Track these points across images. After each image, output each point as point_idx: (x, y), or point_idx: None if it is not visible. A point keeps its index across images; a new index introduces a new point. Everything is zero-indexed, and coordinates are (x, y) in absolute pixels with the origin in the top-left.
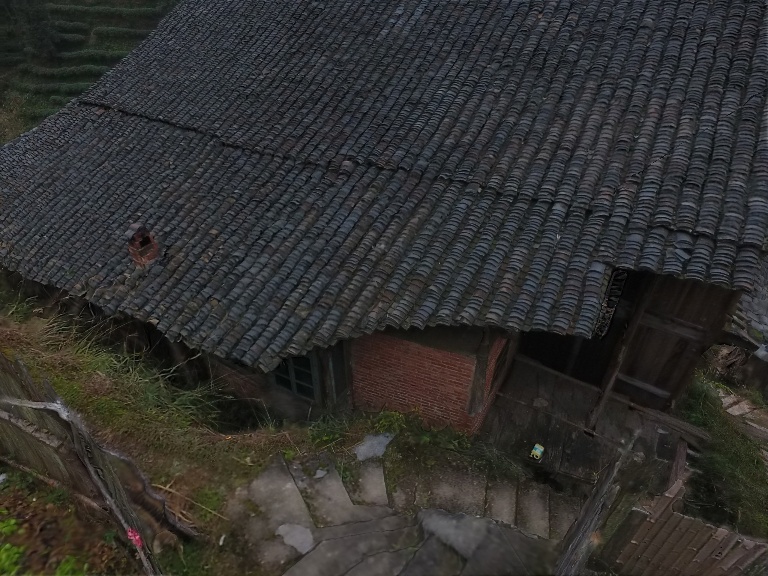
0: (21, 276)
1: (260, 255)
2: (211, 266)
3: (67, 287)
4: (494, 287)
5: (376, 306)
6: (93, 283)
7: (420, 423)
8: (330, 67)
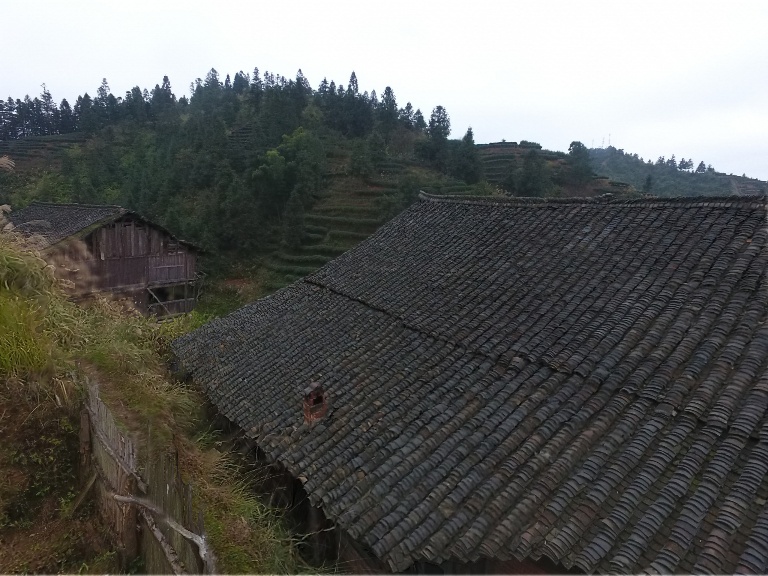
0: (218, 410)
1: (415, 435)
2: (367, 436)
3: (246, 427)
4: (696, 544)
5: (532, 526)
6: (266, 429)
7: None
8: (513, 271)
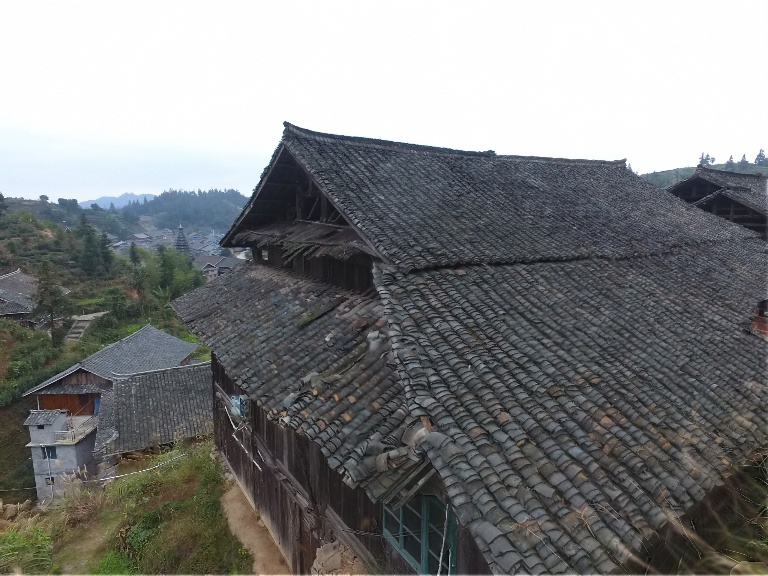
0: None
1: None
2: None
3: None
4: None
5: None
6: None
7: None
8: None
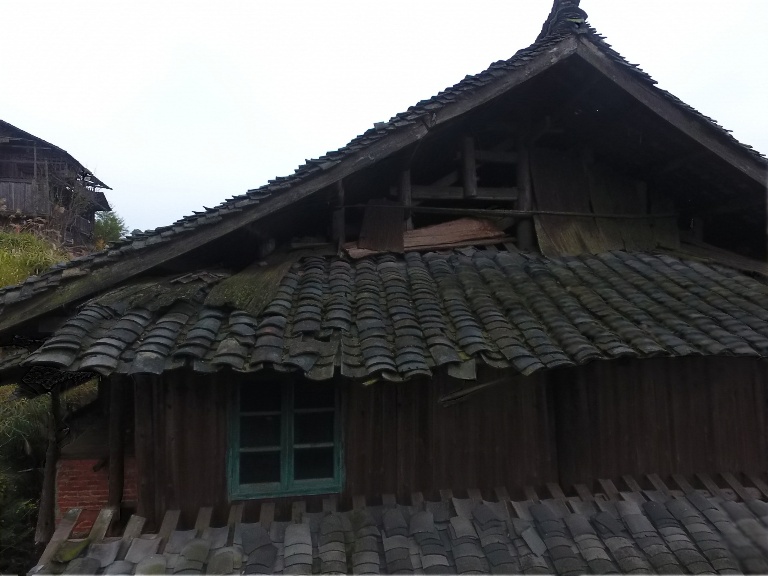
0: None
1: None
2: None
3: None
4: None
5: None
6: None
7: (11, 513)
8: None
